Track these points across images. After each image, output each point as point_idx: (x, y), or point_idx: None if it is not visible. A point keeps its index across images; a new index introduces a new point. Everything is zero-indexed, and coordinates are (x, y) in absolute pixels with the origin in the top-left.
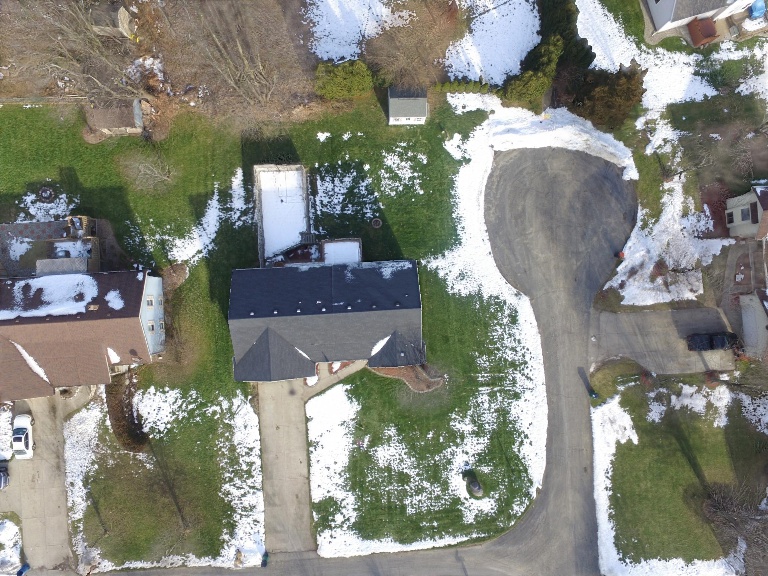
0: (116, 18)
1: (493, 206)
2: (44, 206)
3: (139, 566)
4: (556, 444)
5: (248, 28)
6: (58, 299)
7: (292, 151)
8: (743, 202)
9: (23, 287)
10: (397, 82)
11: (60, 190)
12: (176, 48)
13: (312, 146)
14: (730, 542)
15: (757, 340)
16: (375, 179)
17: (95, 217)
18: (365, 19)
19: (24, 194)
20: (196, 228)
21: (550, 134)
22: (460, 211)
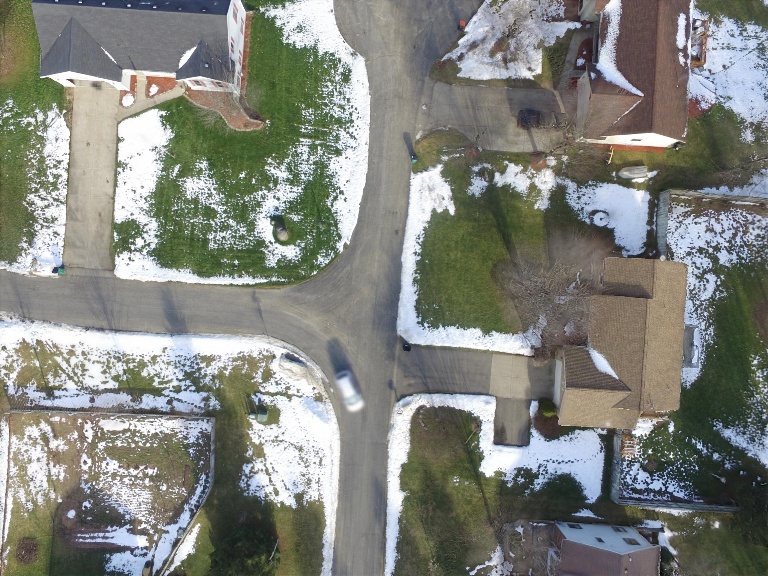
0: None
1: None
2: None
3: None
4: (371, 204)
5: None
6: None
7: None
8: None
9: None
10: None
11: None
12: None
13: None
14: (531, 319)
15: (583, 116)
16: None
17: None
18: None
19: None
20: None
21: None
22: None
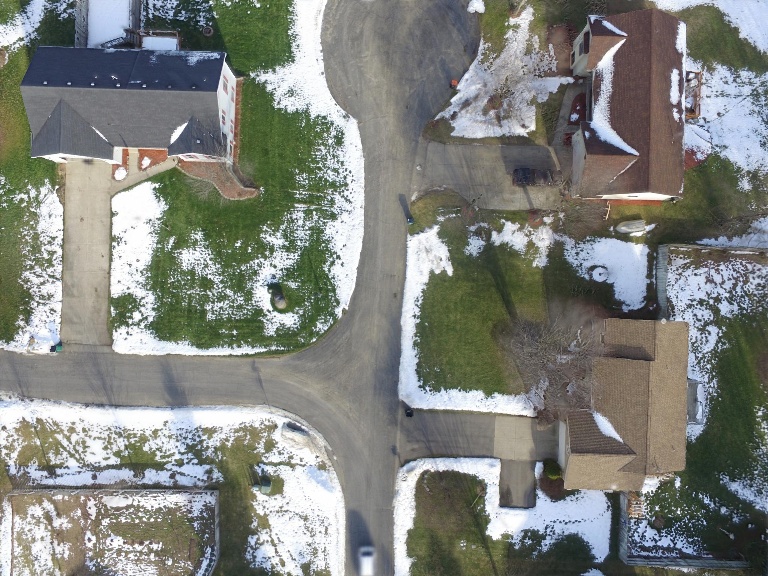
0: None
1: (331, 27)
2: None
3: None
4: (368, 268)
5: None
6: None
7: None
8: (582, 36)
9: None
10: None
11: None
12: None
13: None
14: (533, 379)
15: (578, 175)
16: None
17: None
18: None
19: None
20: (19, 15)
21: None
22: (296, 29)
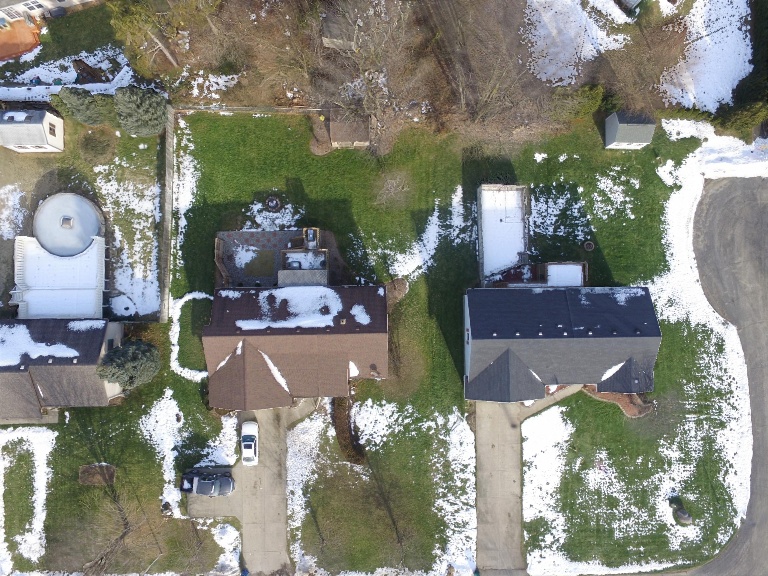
0: (352, 32)
1: (702, 234)
2: (270, 215)
3: None
4: (761, 475)
5: (469, 46)
6: (304, 311)
7: (510, 171)
8: None
9: (267, 297)
10: (623, 107)
11: (286, 200)
12: (399, 63)
13: (529, 166)
14: None
15: None
16: (588, 202)
17: (320, 228)
18: (581, 41)
19: (251, 202)
20: (417, 244)
21: (762, 164)
22: (669, 237)
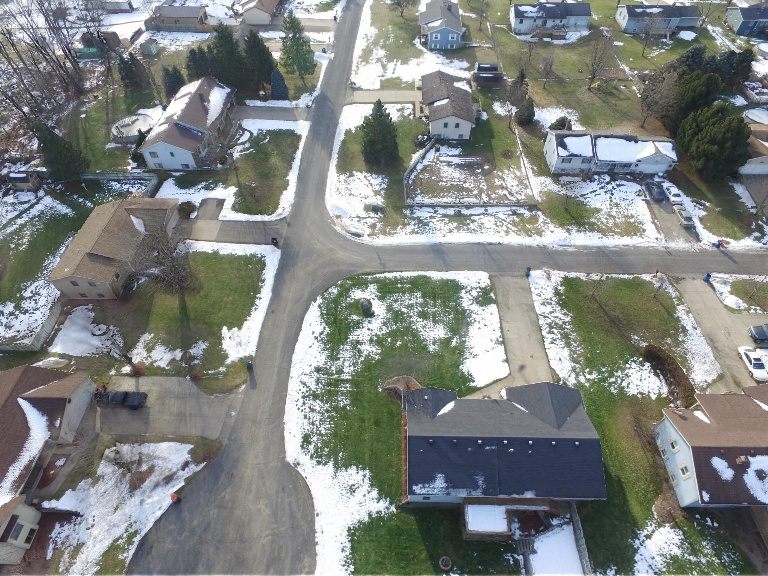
0: None
1: None
2: None
3: (621, 275)
4: (292, 331)
5: None
6: None
7: None
8: (9, 550)
9: None
10: None
11: None
12: None
13: None
14: (180, 260)
15: (83, 394)
16: None
17: None
18: None
19: None
20: (661, 569)
21: None
22: (344, 574)
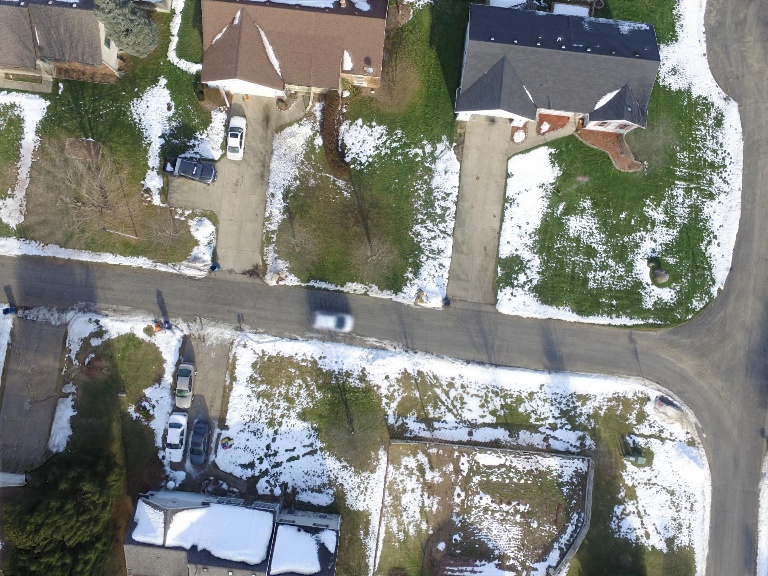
0: None
1: (715, 9)
2: None
3: (323, 286)
4: (744, 250)
5: None
6: None
7: None
8: None
9: None
10: None
11: None
12: None
13: None
14: None
15: None
16: None
17: None
18: None
19: None
20: None
21: None
22: (681, 9)
